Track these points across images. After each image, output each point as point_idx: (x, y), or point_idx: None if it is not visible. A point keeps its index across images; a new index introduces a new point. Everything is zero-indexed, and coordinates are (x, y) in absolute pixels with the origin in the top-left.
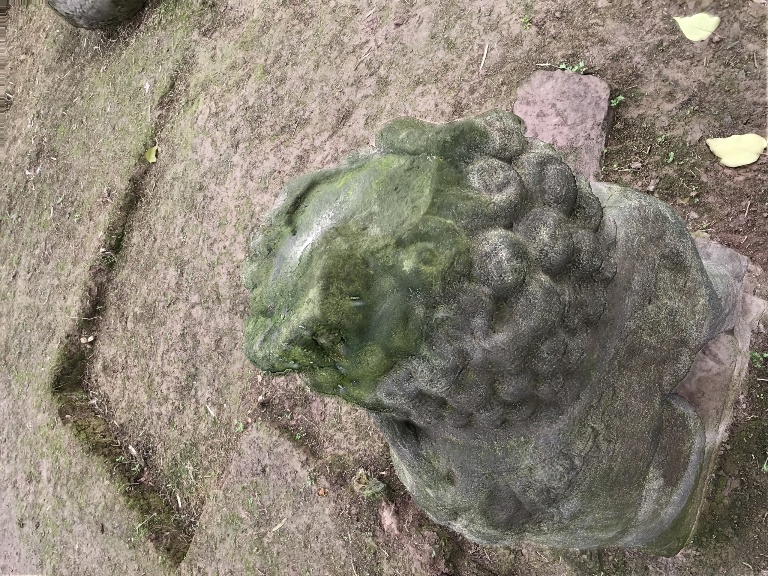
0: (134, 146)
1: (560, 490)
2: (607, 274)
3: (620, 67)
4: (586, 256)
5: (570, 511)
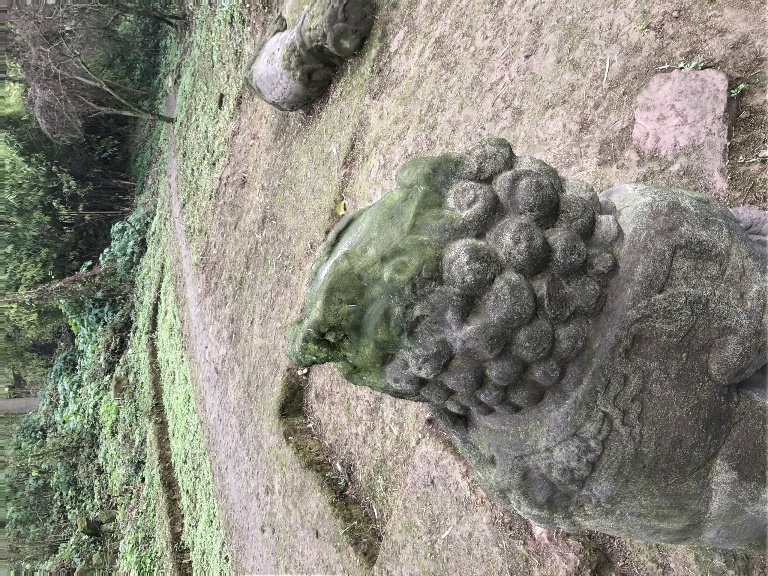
0: (327, 203)
1: (583, 472)
2: (601, 269)
3: (742, 54)
4: (562, 254)
5: (607, 495)
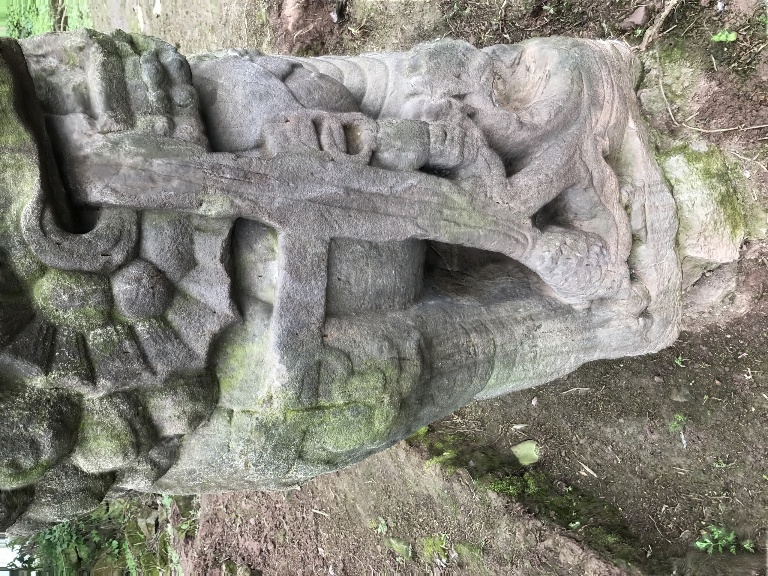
0: None
1: None
2: None
3: None
4: None
5: None
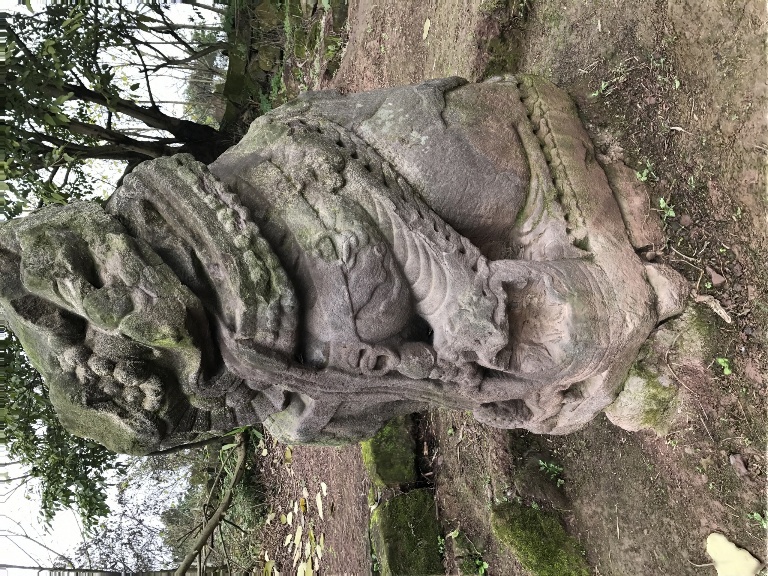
0: None
1: None
2: None
3: None
4: None
5: None
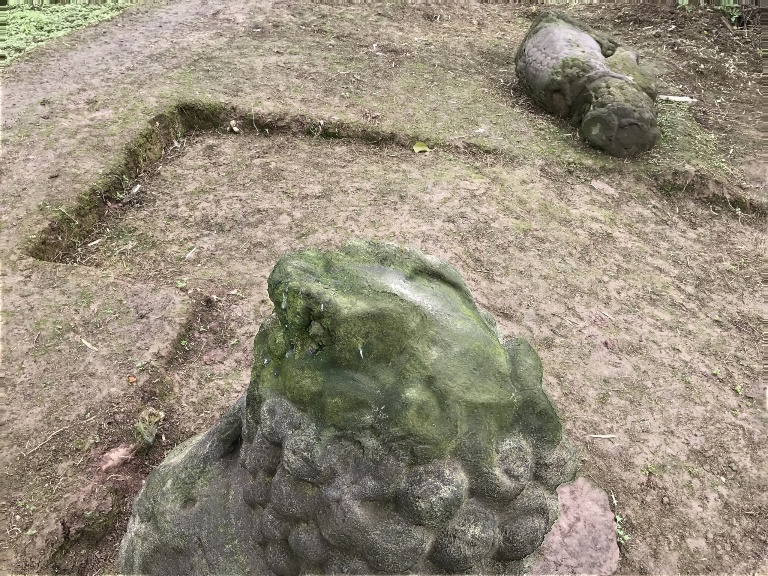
0: (424, 130)
1: None
2: None
3: None
4: None
5: None
